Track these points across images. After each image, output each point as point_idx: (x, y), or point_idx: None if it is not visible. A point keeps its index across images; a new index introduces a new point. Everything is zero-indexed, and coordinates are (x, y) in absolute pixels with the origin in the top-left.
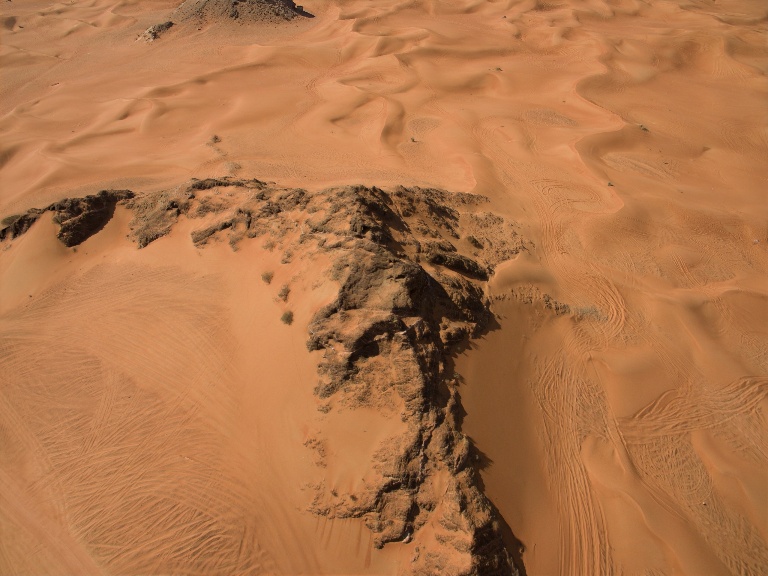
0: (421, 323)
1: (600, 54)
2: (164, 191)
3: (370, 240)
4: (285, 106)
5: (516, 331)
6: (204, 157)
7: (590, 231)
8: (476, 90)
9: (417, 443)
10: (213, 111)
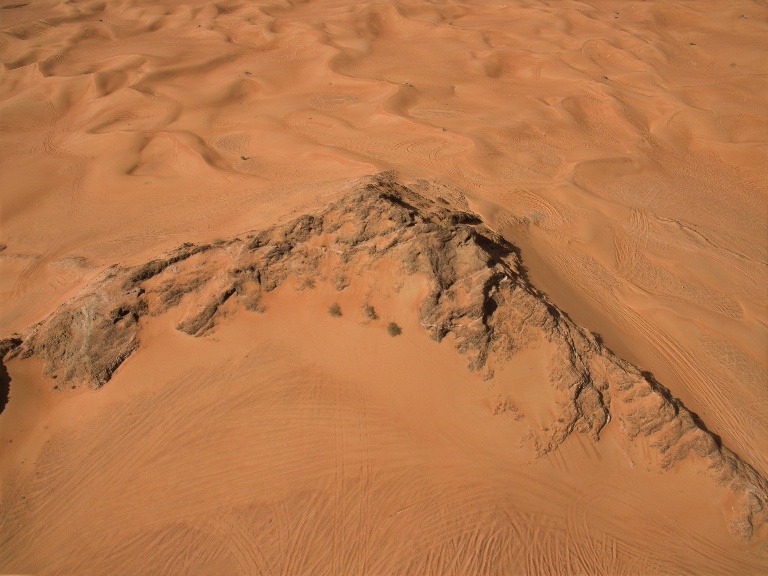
0: None
1: (317, 38)
2: (71, 311)
3: (422, 223)
4: (47, 180)
5: (526, 247)
6: (8, 272)
7: (476, 165)
8: (242, 98)
9: (571, 349)
10: None
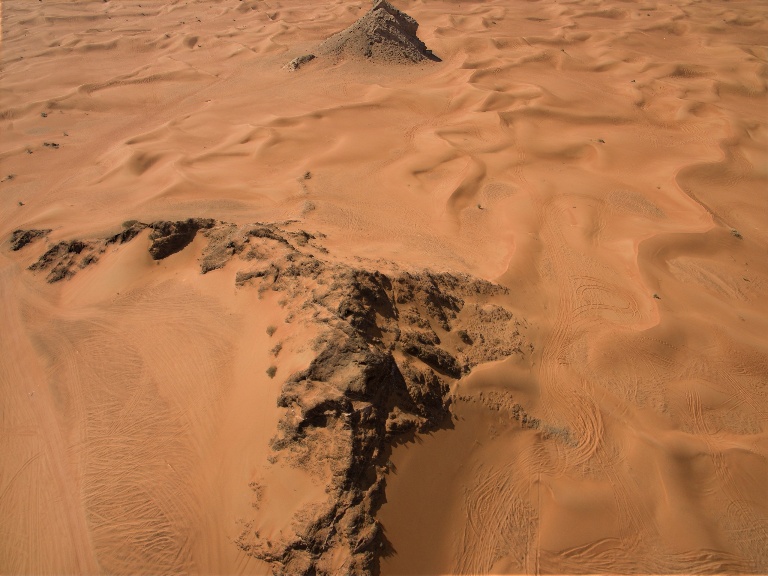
0: (369, 409)
1: (725, 137)
2: (234, 228)
3: (349, 324)
4: (379, 151)
5: (470, 434)
6: (291, 192)
7: (603, 346)
8: (570, 159)
9: (330, 515)
10: (317, 146)
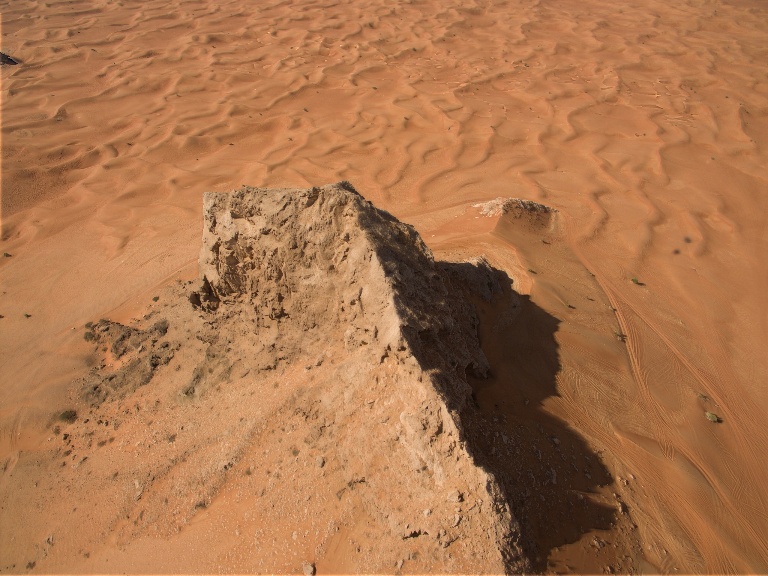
0: None
1: None
2: None
3: None
4: None
5: None
6: None
7: None
8: (35, 105)
9: None
10: None
